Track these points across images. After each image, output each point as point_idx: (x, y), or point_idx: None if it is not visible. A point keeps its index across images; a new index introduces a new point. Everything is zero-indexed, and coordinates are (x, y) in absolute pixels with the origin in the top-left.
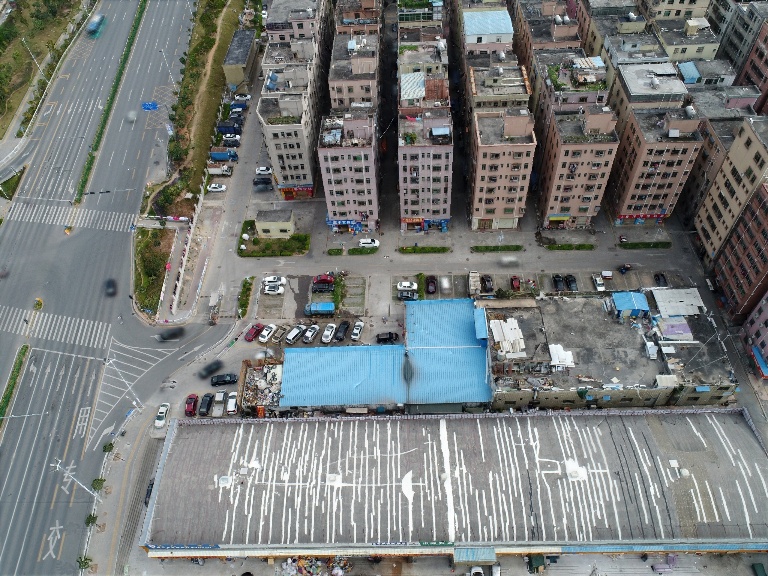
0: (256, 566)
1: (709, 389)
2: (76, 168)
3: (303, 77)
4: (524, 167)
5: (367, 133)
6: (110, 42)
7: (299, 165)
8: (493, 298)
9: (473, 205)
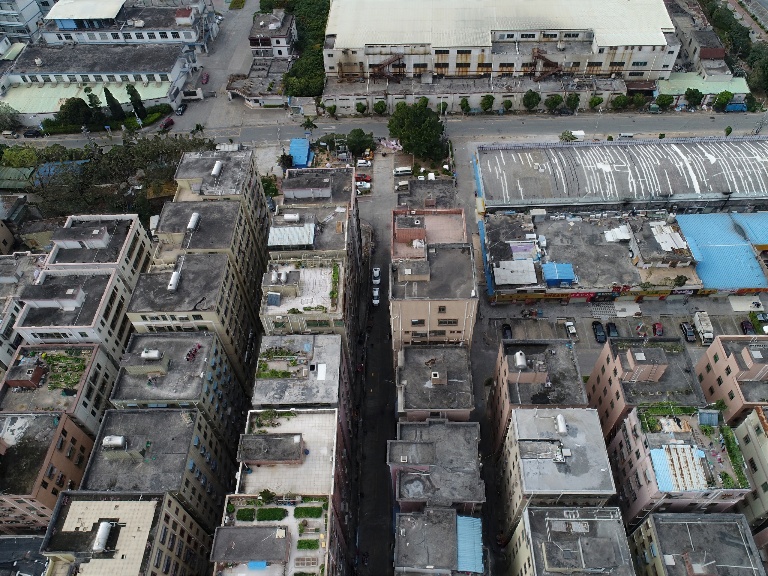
0: None
1: None
2: None
3: None
4: None
5: None
6: None
7: None
8: None
9: None
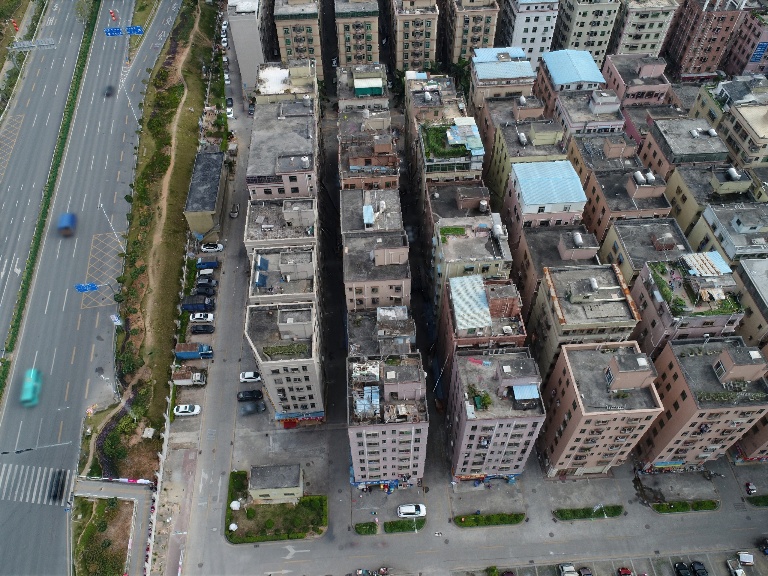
0: None
1: None
2: None
3: (306, 270)
4: (638, 428)
5: (418, 394)
6: (29, 160)
7: (306, 395)
8: None
9: (555, 456)
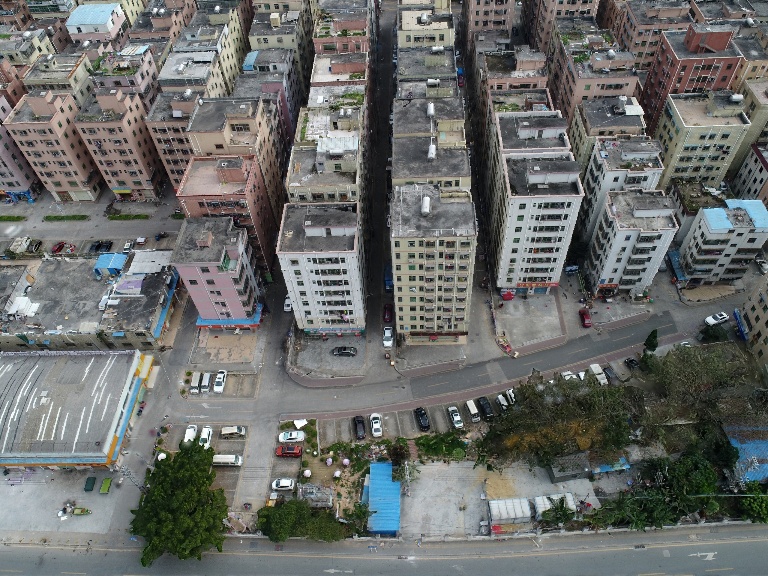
0: None
1: None
2: None
3: None
4: (57, 143)
5: None
6: None
7: None
8: (7, 258)
9: None
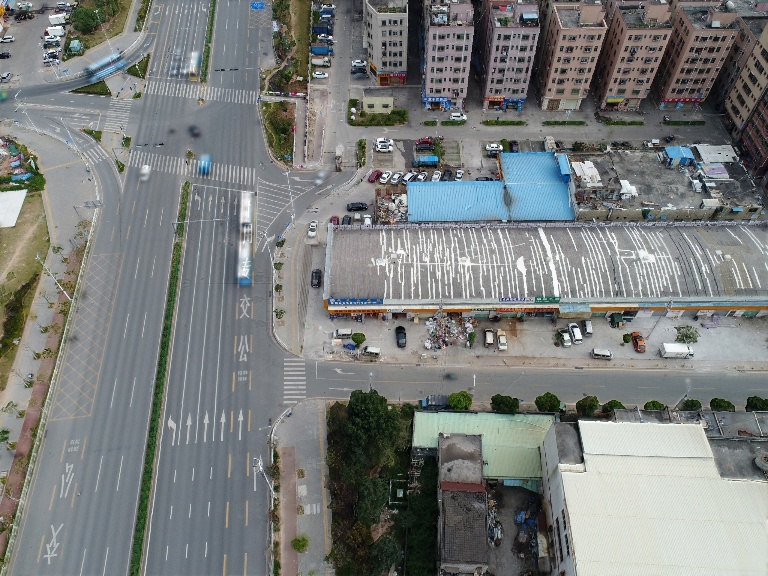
0: (405, 324)
1: (742, 210)
2: (195, 56)
3: None
4: (594, 50)
5: (469, 17)
6: None
7: (398, 52)
8: (569, 151)
9: (546, 86)
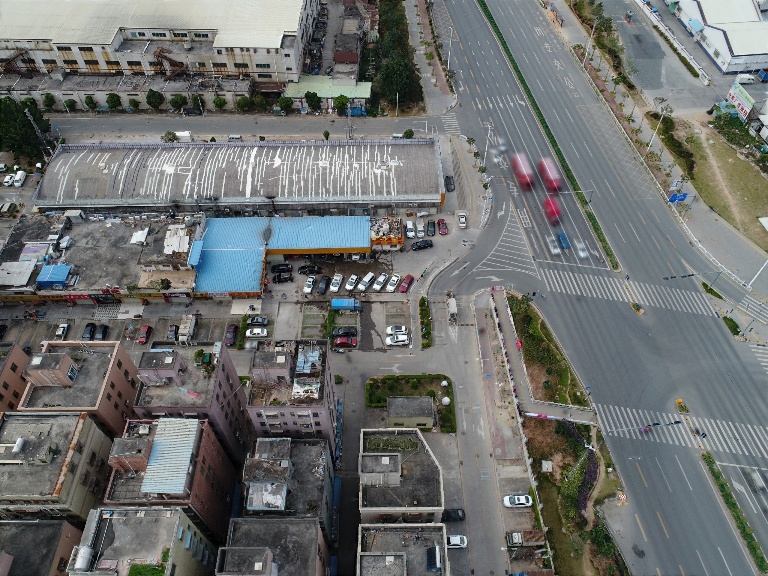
0: None
1: None
2: None
3: None
4: None
5: None
6: None
7: None
8: None
9: None
